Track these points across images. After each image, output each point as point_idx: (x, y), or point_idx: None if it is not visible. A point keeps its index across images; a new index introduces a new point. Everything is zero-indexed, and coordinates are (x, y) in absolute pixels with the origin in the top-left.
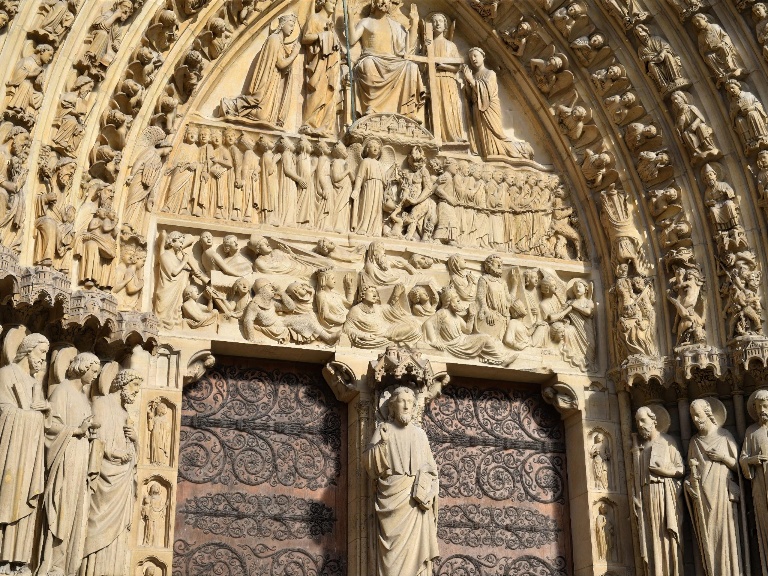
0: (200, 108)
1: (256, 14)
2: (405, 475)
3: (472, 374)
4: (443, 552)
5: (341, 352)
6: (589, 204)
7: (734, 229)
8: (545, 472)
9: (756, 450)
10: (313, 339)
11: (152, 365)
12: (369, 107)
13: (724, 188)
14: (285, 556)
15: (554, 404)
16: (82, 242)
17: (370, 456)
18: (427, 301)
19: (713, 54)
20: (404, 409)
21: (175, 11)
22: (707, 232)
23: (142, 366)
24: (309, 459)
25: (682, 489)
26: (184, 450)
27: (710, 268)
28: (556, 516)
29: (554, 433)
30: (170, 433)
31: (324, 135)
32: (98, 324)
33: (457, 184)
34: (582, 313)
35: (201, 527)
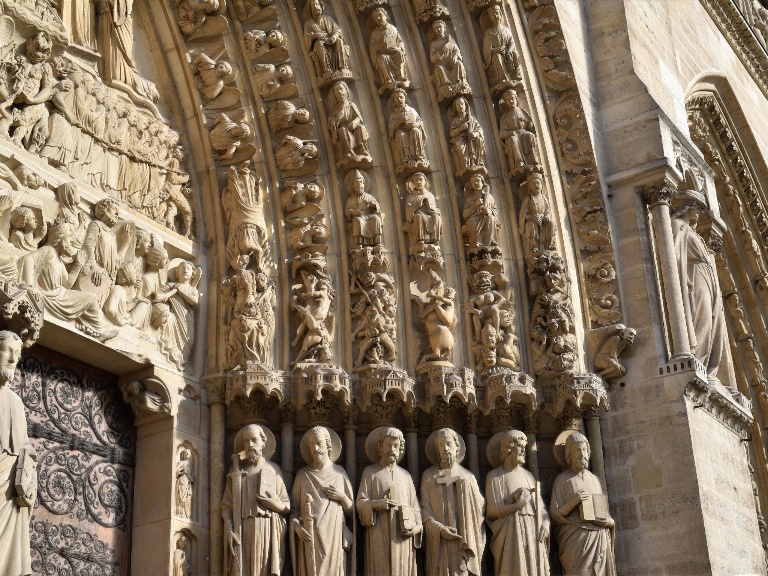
0: None
1: None
2: (4, 452)
3: (52, 342)
4: None
5: None
6: (209, 177)
7: None
8: (110, 487)
9: (380, 493)
10: None
11: None
12: None
13: (371, 200)
14: None
15: (137, 403)
16: None
17: None
18: (31, 230)
19: (388, 55)
20: (9, 361)
21: None
22: (344, 243)
23: None
24: None
25: (287, 528)
26: None
27: (341, 283)
28: (115, 545)
29: (124, 440)
30: None
31: None
32: None
33: (80, 98)
34: (187, 300)
35: None
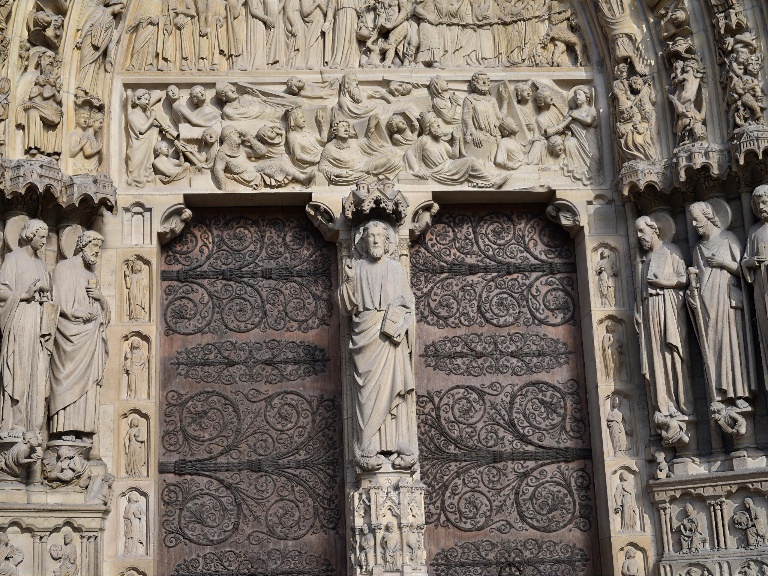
0: None
1: None
2: (375, 310)
3: (467, 200)
4: (443, 384)
5: (318, 192)
6: (587, 3)
7: (729, 9)
8: (554, 294)
9: (756, 251)
10: (287, 182)
11: (126, 224)
12: None
13: None
14: (278, 399)
15: (558, 222)
16: (24, 112)
17: (339, 294)
18: (406, 129)
19: None
20: (374, 244)
21: None
22: (706, 17)
23: (116, 226)
24: (299, 302)
25: (684, 300)
26: (172, 304)
27: (711, 57)
28: (567, 338)
29: (563, 253)
30: (148, 289)
31: None
32: (38, 191)
33: (437, 1)
34: (582, 123)
35: (193, 377)
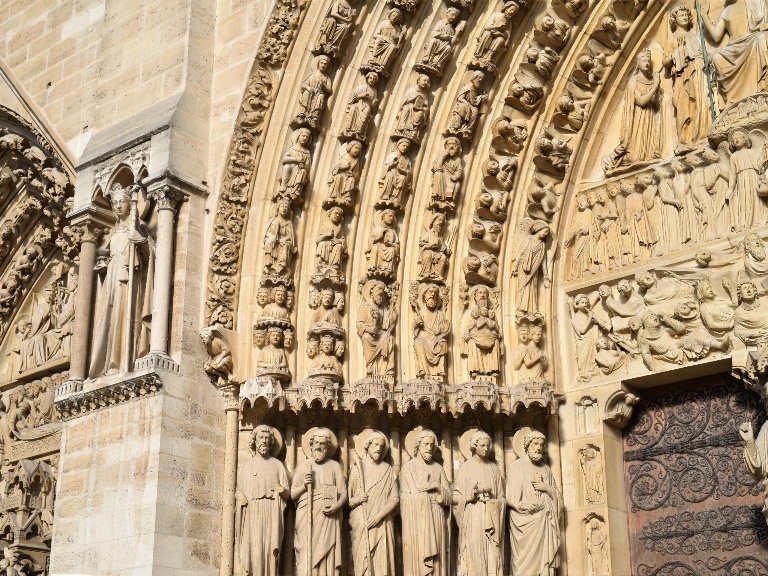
0: (589, 174)
1: (608, 70)
2: None
3: None
4: None
5: (737, 356)
6: None
7: None
8: None
9: None
10: (706, 352)
11: (580, 417)
12: (726, 101)
13: None
14: (736, 565)
15: None
16: (466, 343)
17: (744, 459)
18: None
19: None
20: None
21: (518, 115)
22: None
23: (570, 421)
24: None
25: None
26: (636, 482)
27: None
28: None
29: None
30: (601, 473)
31: (691, 149)
32: None
33: None
34: None
35: (659, 550)
